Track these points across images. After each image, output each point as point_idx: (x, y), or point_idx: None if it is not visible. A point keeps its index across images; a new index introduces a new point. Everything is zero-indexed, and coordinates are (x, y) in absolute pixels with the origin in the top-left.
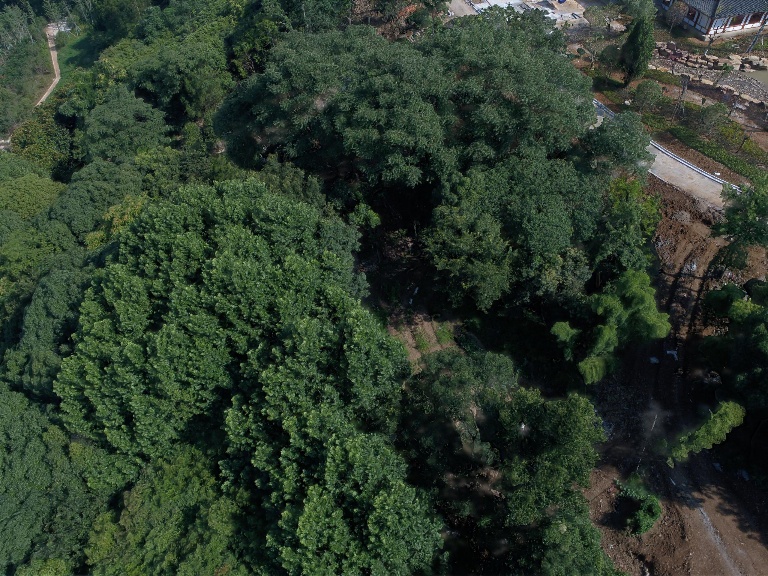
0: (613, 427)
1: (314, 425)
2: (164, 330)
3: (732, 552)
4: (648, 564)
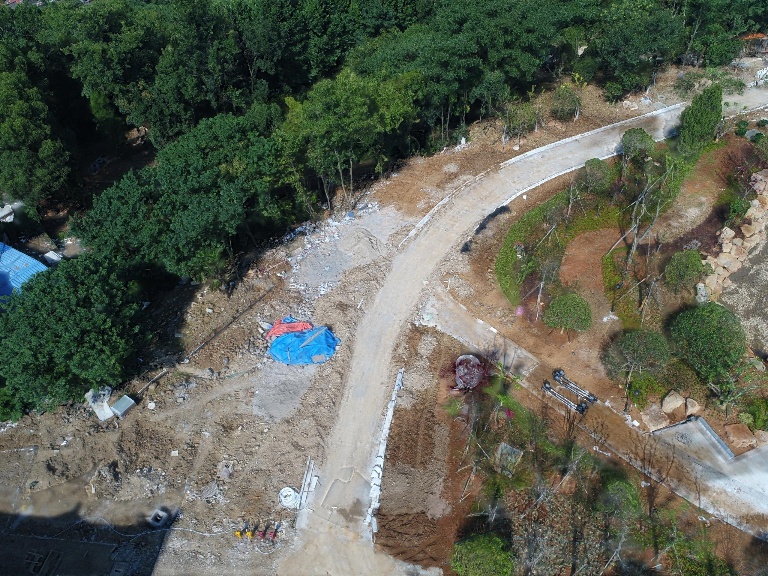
0: None
1: (235, 2)
2: None
3: None
4: None
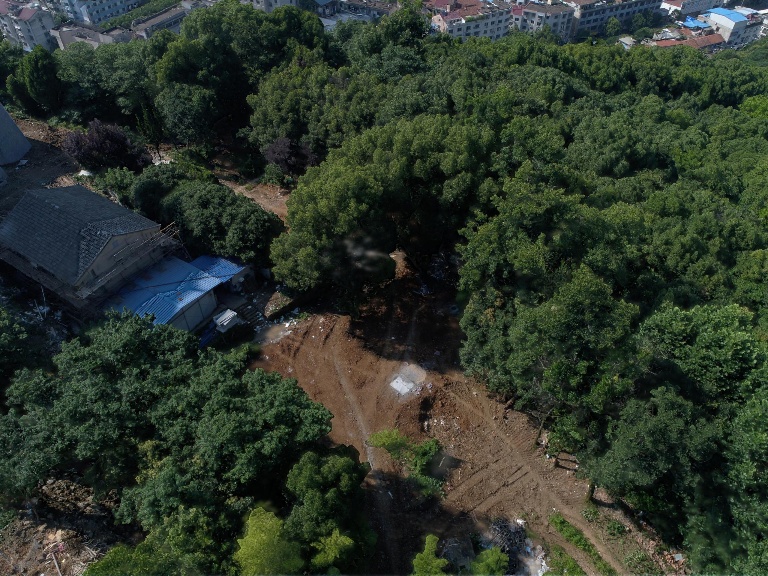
0: (442, 553)
1: None
2: None
3: (358, 434)
4: (424, 432)
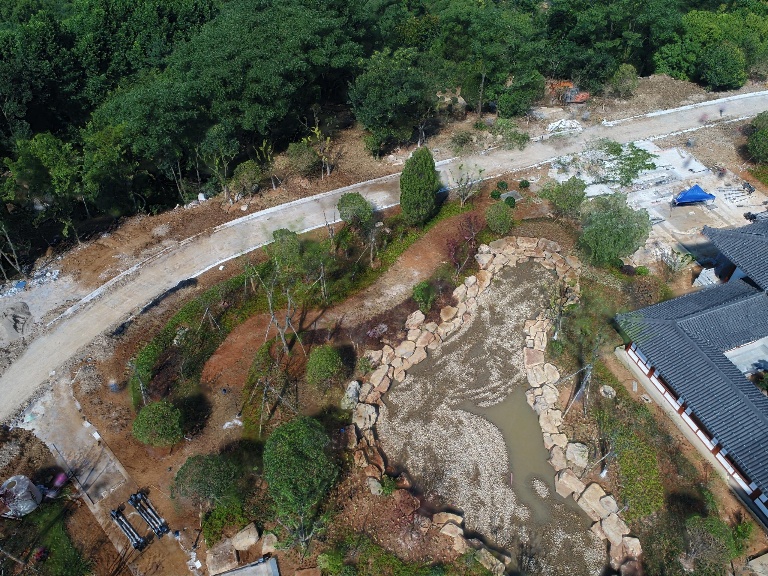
0: None
1: (2, 37)
2: (84, 1)
3: None
4: None
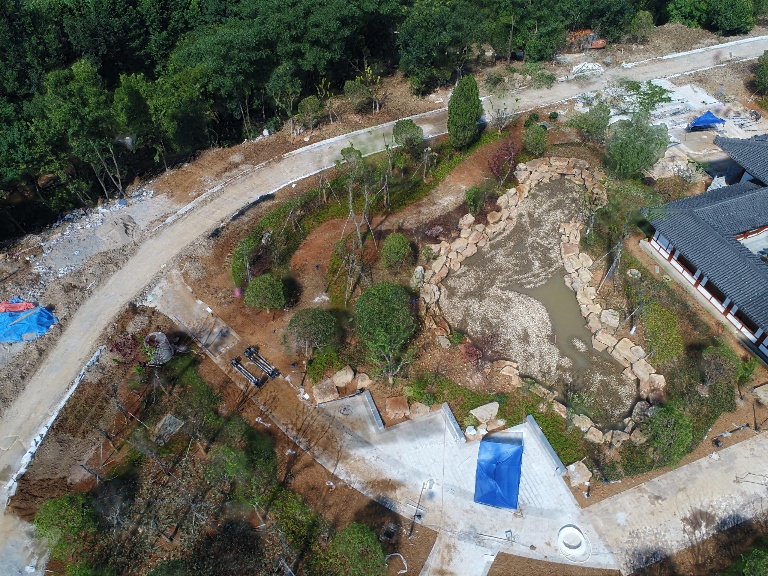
0: None
1: None
2: None
3: None
4: None
